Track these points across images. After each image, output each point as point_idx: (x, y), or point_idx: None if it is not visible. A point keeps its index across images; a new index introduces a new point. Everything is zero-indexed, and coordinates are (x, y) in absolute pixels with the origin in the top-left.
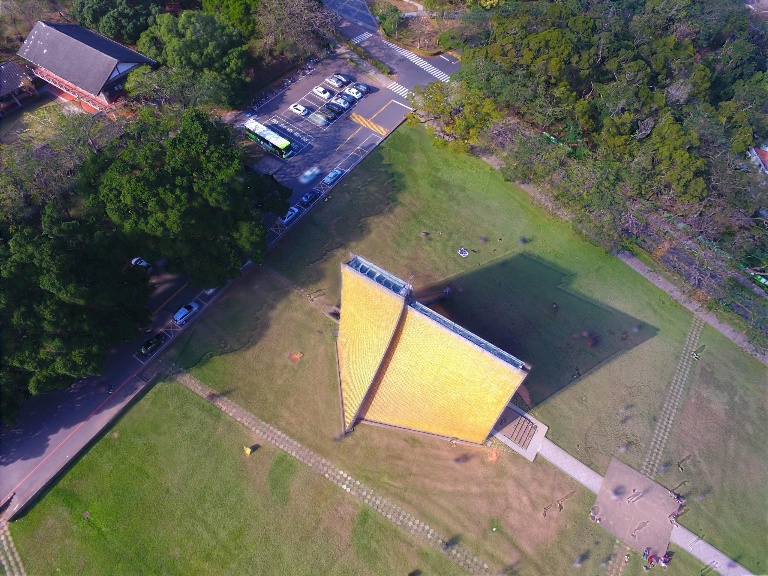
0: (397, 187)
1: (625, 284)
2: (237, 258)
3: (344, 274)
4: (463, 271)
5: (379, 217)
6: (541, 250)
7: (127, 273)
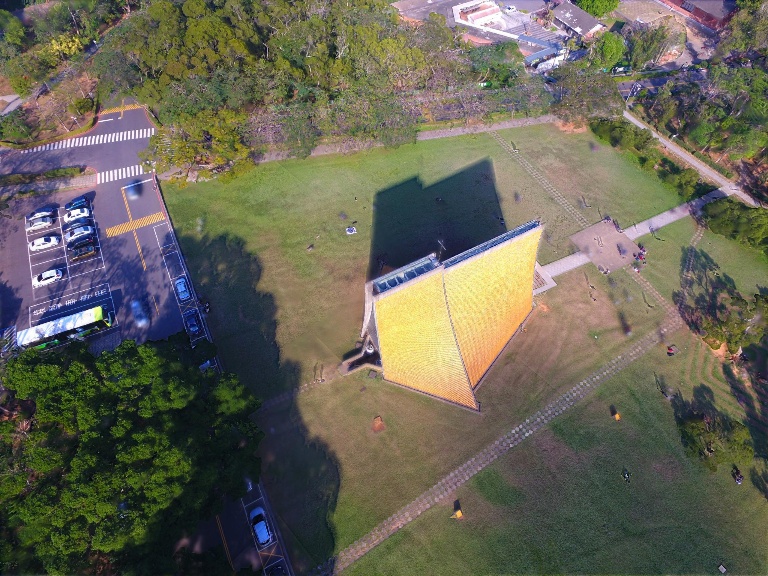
0: (240, 242)
1: (443, 151)
2: (247, 424)
3: (377, 306)
4: (370, 241)
5: (264, 274)
6: (383, 179)
7: (180, 575)
